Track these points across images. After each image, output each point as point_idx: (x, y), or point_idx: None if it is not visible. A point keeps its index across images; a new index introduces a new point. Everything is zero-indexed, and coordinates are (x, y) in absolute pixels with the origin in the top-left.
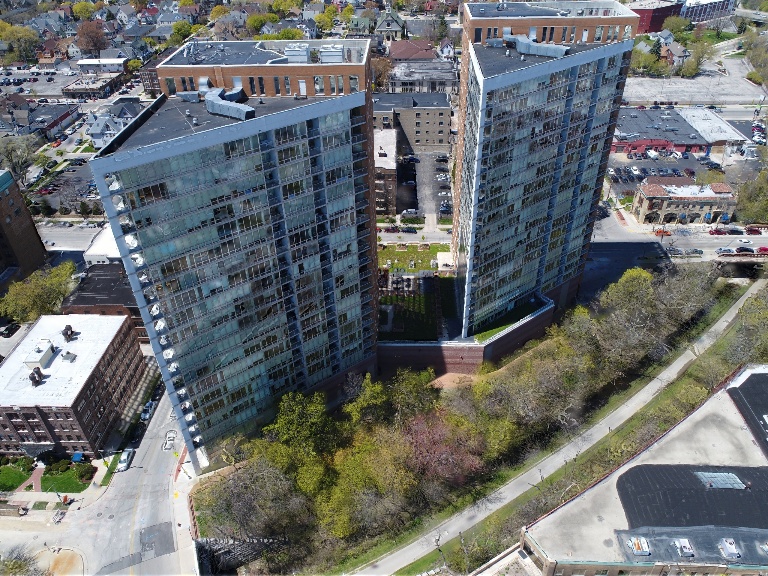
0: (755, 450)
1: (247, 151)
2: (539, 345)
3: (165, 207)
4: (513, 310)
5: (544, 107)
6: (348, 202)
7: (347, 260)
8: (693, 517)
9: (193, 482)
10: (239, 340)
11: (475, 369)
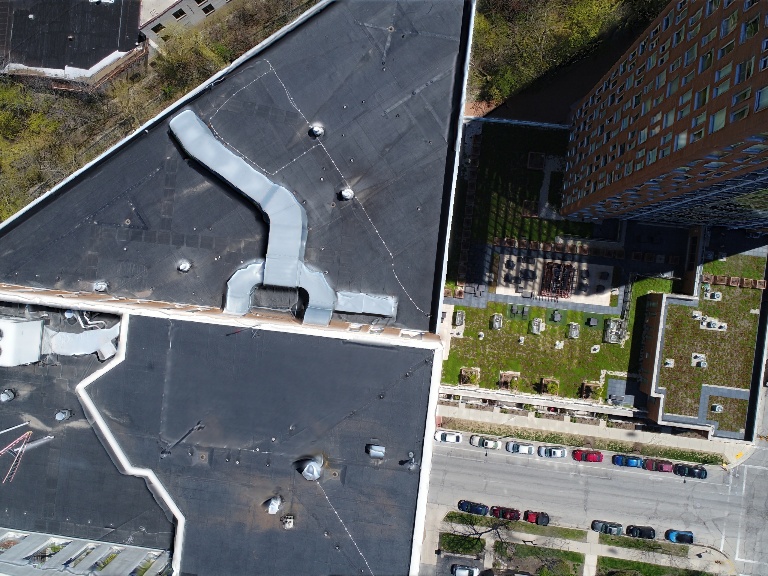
0: None
1: None
2: None
3: None
4: None
5: None
6: None
7: None
8: None
9: None
10: None
11: None
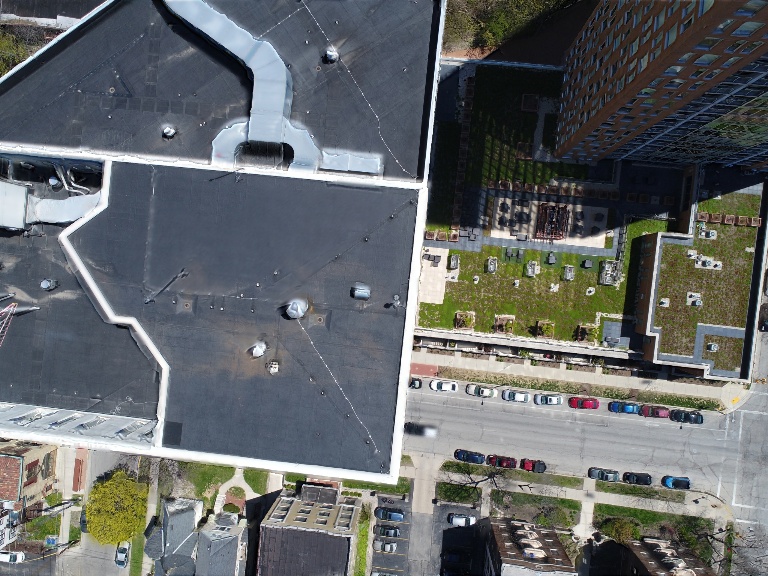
0: None
1: None
2: None
3: None
4: None
5: None
6: None
7: None
8: None
9: None
10: None
11: None
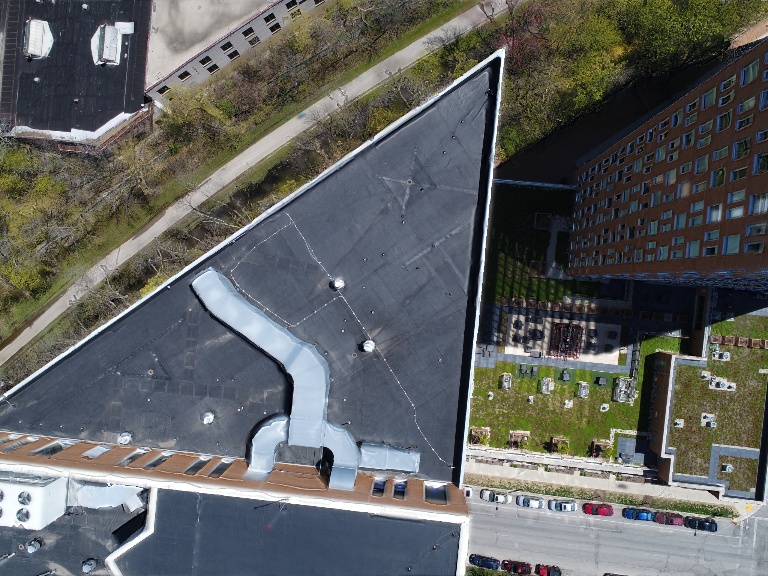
0: None
1: None
2: None
3: None
4: None
5: None
6: None
7: None
8: None
9: None
10: None
11: None
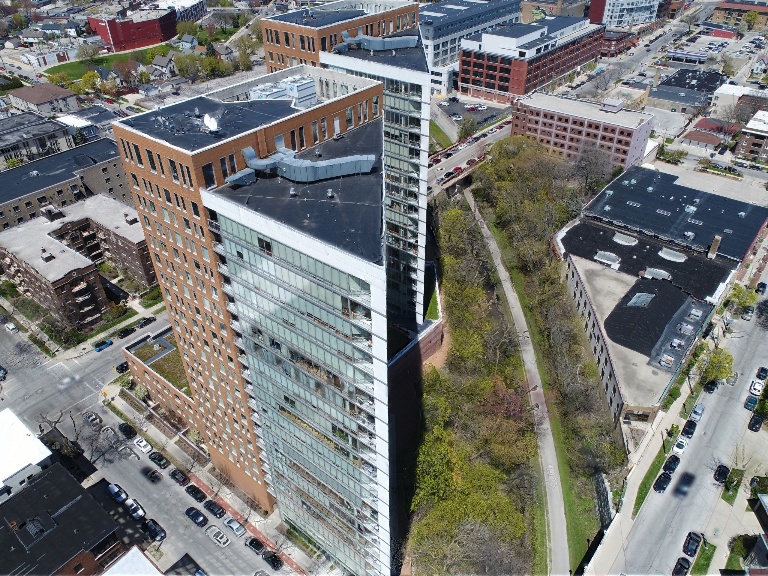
0: (623, 276)
1: None
2: None
3: None
4: None
5: None
6: None
7: None
8: (658, 327)
9: None
10: None
11: (437, 345)
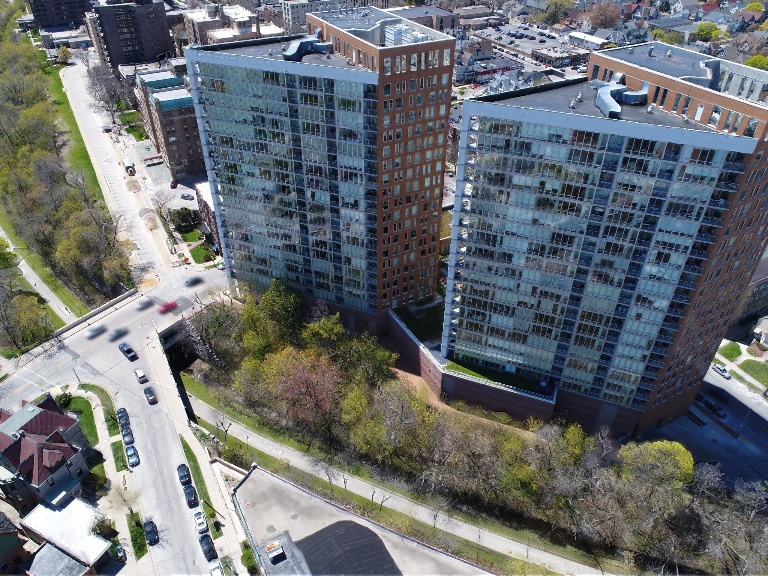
0: None
1: (277, 83)
2: (521, 429)
3: (223, 98)
4: (513, 375)
5: (561, 165)
6: (357, 163)
7: (354, 213)
8: None
9: (226, 298)
10: (264, 221)
11: (436, 390)
